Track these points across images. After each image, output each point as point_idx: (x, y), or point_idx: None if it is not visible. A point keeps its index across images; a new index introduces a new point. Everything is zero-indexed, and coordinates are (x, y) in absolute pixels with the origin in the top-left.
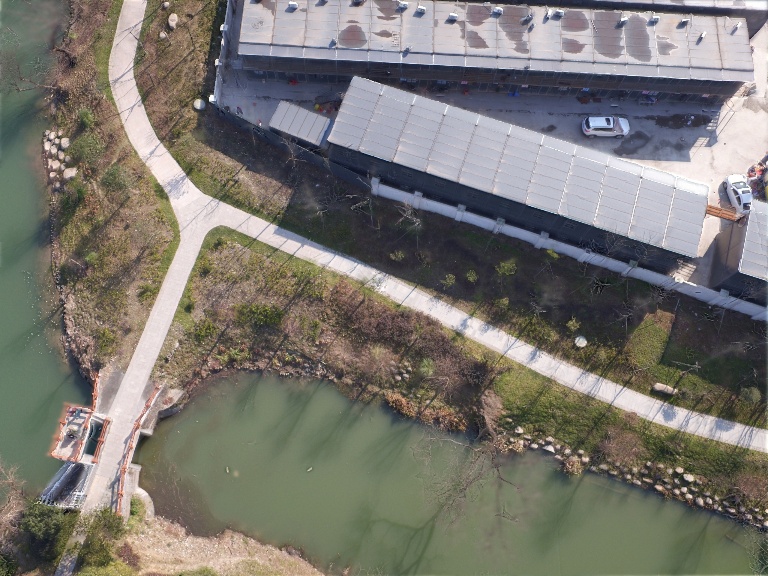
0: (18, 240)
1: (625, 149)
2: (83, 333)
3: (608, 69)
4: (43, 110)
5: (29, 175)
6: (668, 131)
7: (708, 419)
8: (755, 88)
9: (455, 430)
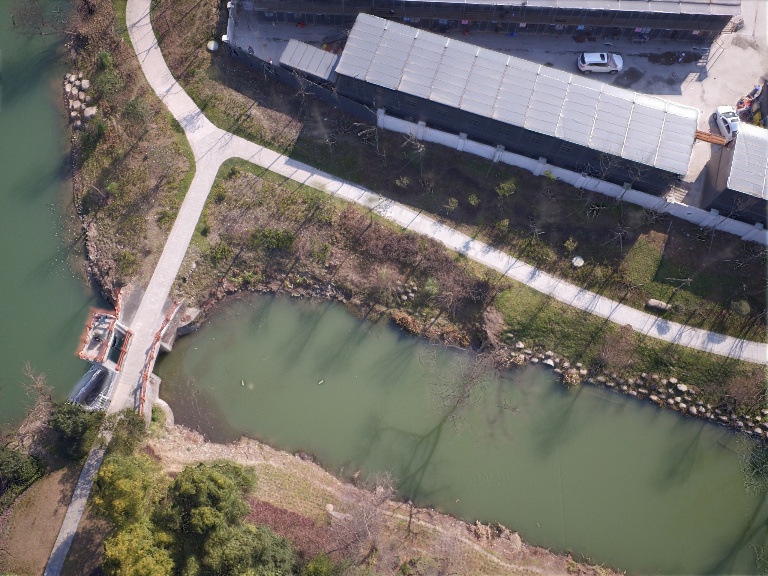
0: (42, 174)
1: (619, 84)
2: (105, 257)
3: (601, 4)
4: (64, 55)
5: (51, 115)
6: (660, 67)
7: (700, 332)
8: (742, 23)
9: None
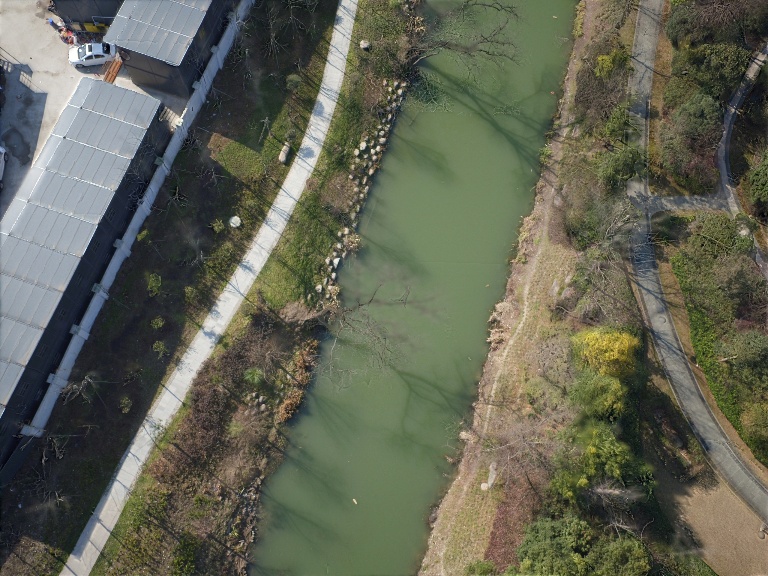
0: None
1: (22, 154)
2: None
3: None
4: None
5: None
6: (7, 109)
7: (313, 122)
8: None
9: (317, 351)
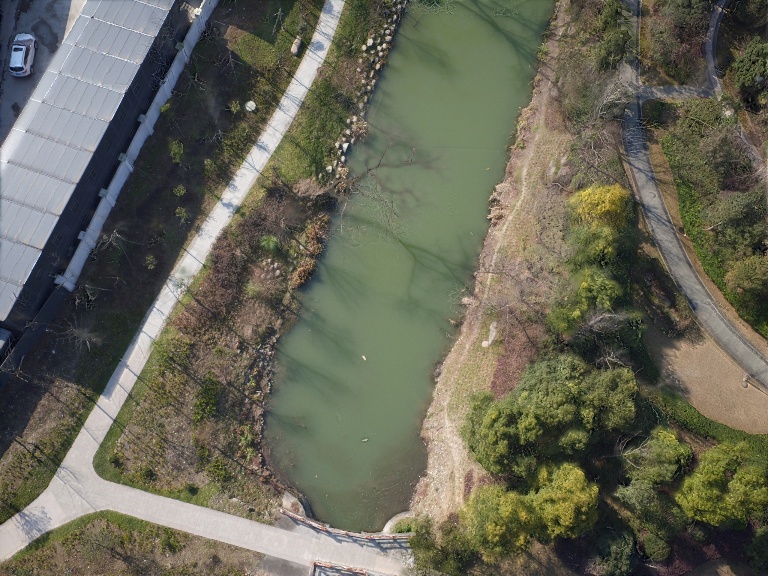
0: None
1: (51, 43)
2: None
3: None
4: None
5: None
6: (36, 3)
7: (323, 19)
8: None
9: (328, 225)
